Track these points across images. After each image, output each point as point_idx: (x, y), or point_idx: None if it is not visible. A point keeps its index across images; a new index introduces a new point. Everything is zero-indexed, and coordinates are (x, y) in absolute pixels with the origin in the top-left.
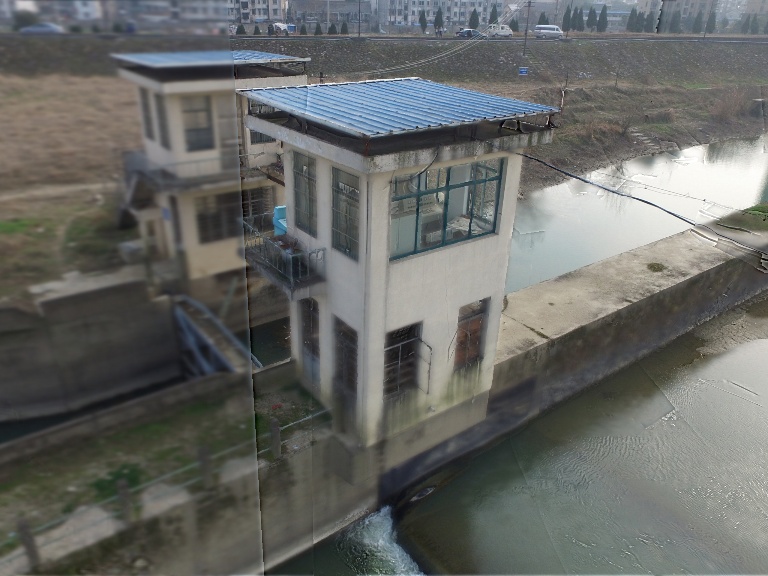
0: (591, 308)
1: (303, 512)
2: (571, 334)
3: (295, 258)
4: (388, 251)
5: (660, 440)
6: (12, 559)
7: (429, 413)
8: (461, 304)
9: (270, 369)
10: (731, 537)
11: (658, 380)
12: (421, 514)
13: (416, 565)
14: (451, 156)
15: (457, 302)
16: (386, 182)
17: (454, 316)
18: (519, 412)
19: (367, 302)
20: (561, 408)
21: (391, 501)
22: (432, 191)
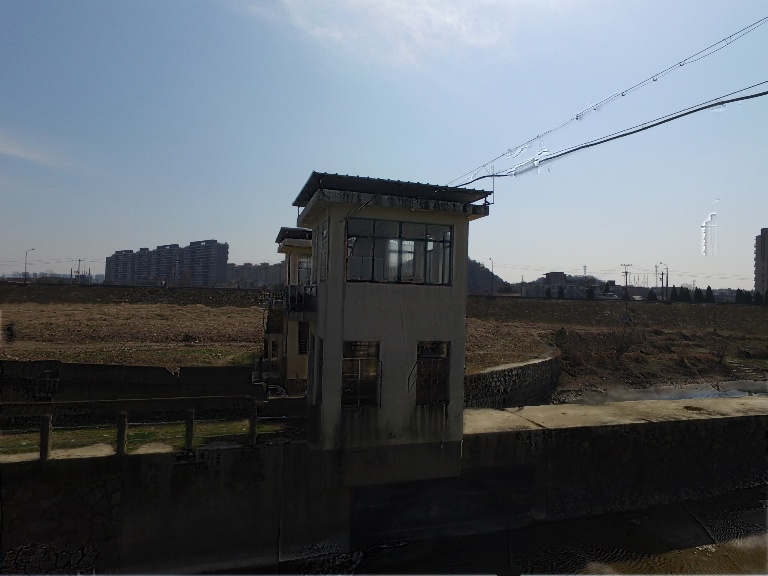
0: (603, 419)
1: (270, 516)
2: (572, 430)
3: (293, 287)
4: (344, 271)
5: (686, 563)
6: None
7: (391, 440)
8: (419, 339)
9: (284, 399)
10: None
11: (701, 517)
12: (385, 561)
13: None
14: (390, 203)
15: (414, 335)
16: (342, 218)
17: (412, 348)
18: (517, 502)
19: (326, 308)
20: (577, 521)
21: (364, 547)
22: (385, 237)
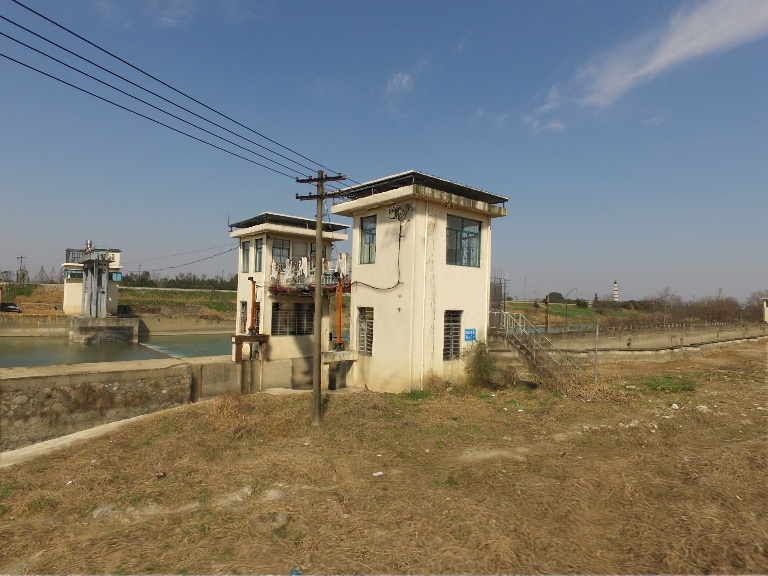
0: None
1: None
2: None
3: None
4: None
5: None
6: (332, 252)
7: None
8: None
9: None
10: None
11: None
12: None
13: None
14: None
15: None
16: None
17: None
18: None
19: None
20: None
21: None
22: None
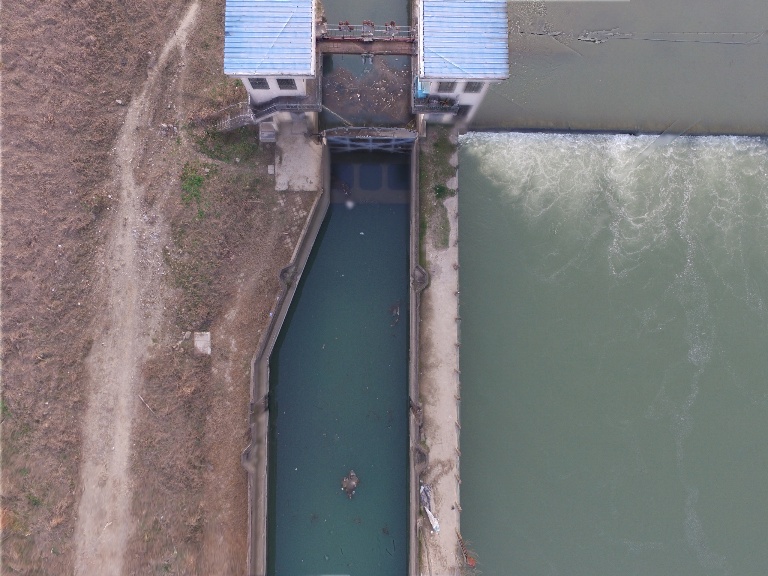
0: None
1: None
2: None
3: None
4: None
5: None
6: None
7: None
8: None
9: None
10: (527, 42)
11: None
12: None
13: (474, 132)
14: None
15: None
16: None
17: None
18: None
19: None
20: None
21: None
22: None
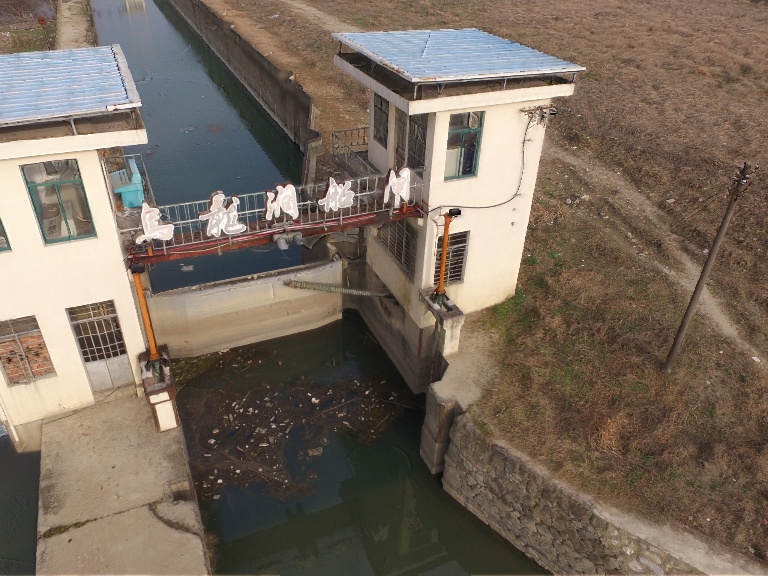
0: None
1: None
2: None
3: None
4: None
5: None
6: None
7: None
8: None
9: None
10: None
11: None
12: None
13: None
14: None
15: None
16: None
17: None
18: None
19: None
20: None
21: None
22: None
